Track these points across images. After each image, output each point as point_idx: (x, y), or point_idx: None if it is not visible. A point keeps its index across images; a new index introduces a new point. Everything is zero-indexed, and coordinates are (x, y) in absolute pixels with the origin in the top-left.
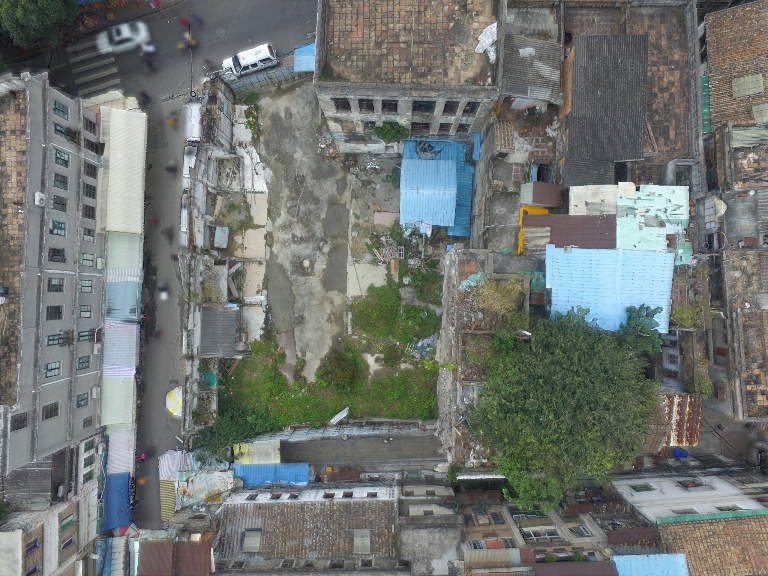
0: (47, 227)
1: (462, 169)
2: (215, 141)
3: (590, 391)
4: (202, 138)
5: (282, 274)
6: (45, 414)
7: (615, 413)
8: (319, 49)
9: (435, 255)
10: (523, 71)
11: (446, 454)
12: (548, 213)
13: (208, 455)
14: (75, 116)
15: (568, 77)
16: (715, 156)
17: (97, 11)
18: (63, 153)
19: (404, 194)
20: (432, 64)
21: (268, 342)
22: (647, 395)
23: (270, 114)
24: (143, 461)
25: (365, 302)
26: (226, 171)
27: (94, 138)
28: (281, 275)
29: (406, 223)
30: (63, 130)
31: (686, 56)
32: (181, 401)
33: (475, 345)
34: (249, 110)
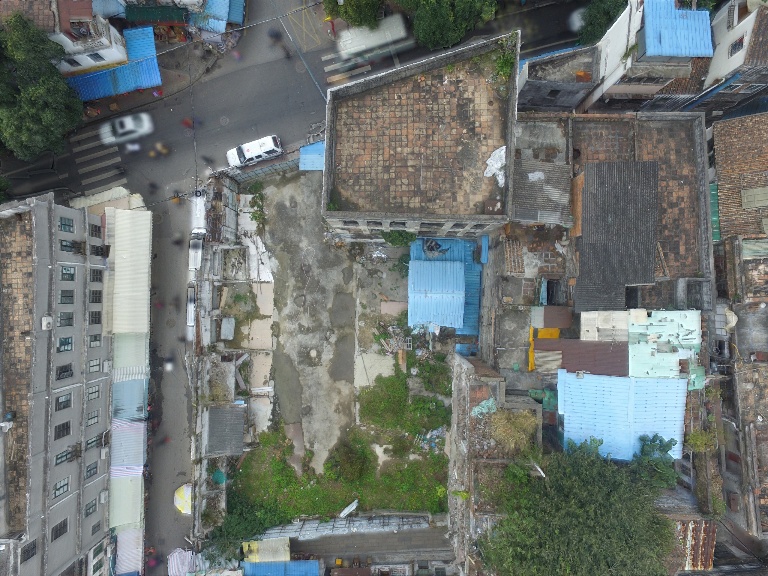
0: (54, 347)
1: (470, 267)
2: (221, 239)
3: (607, 546)
4: (207, 234)
5: (289, 364)
6: (54, 534)
7: (633, 569)
8: (327, 178)
9: (443, 352)
10: (532, 195)
11: (459, 572)
12: (558, 329)
13: (217, 555)
14: (80, 225)
15: (578, 199)
16: (725, 266)
17: (100, 101)
18: (69, 267)
19: (412, 297)
20: (441, 188)
21: (276, 434)
22: (663, 536)
23: (275, 203)
24: (151, 554)
25: (373, 393)
26: (231, 261)
27: (99, 241)
28: (288, 365)
29: (414, 323)
30: (69, 243)
31: (695, 171)
32: (189, 500)
33: (488, 473)
34: (254, 199)
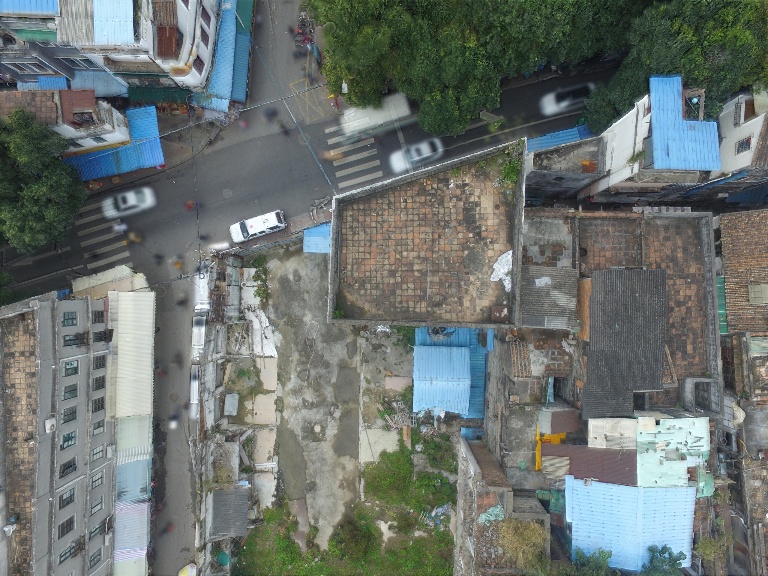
0: (58, 446)
1: (475, 350)
2: (224, 320)
3: None
4: (211, 313)
5: (293, 439)
6: None
7: None
8: (333, 286)
9: (449, 433)
10: (539, 301)
11: None
12: None
13: None
14: (83, 315)
15: (585, 302)
16: (733, 362)
17: None
18: (72, 361)
19: (417, 385)
20: (447, 292)
21: (280, 510)
22: None
23: (278, 276)
24: None
25: (377, 469)
26: (235, 336)
27: (102, 326)
28: (292, 440)
29: None
30: (72, 337)
31: (702, 269)
32: None
33: None
34: (257, 273)
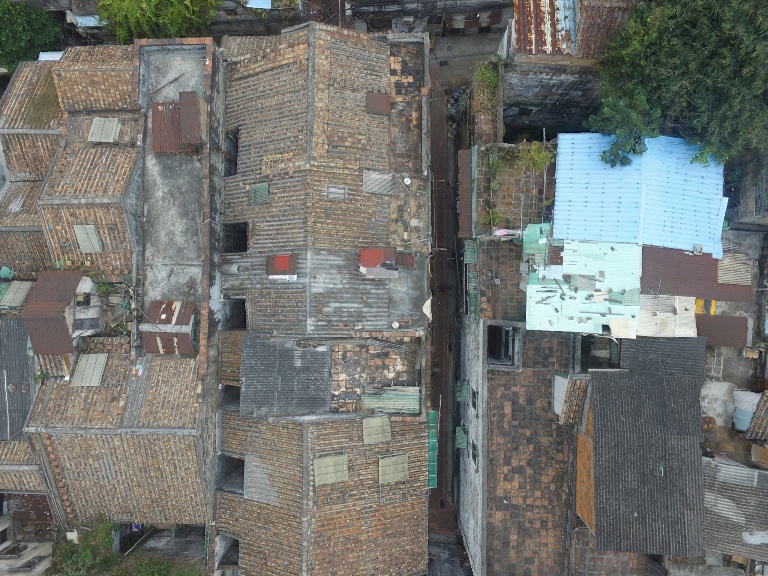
0: None
1: None
2: None
3: None
4: None
5: None
6: None
7: None
8: None
9: None
10: (765, 510)
11: None
12: None
13: None
14: None
15: None
16: None
17: None
18: None
19: None
20: None
21: None
22: None
23: None
24: None
25: None
26: None
27: None
28: None
29: None
30: None
31: (487, 516)
32: None
33: None
34: None
